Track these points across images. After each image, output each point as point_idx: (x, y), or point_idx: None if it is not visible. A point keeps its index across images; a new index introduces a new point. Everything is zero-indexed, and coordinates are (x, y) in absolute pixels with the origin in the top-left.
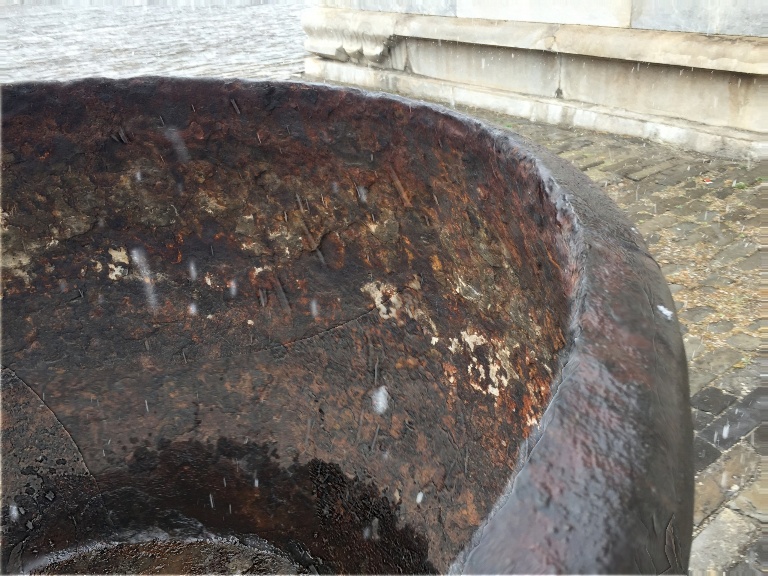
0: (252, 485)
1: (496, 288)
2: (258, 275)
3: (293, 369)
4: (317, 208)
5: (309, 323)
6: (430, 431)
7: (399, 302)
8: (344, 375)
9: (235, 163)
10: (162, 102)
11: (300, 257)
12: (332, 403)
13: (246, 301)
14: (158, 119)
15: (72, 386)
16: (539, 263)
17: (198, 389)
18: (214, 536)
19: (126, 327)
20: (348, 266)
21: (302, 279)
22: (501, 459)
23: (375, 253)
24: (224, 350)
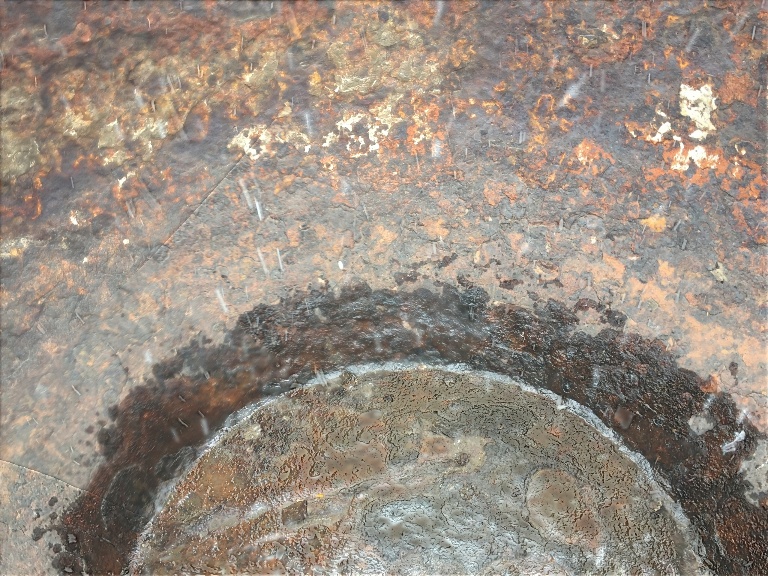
0: (205, 380)
1: (386, 63)
2: (122, 187)
3: (181, 260)
4: (189, 82)
5: (181, 208)
6: (324, 218)
7: (269, 136)
8: (229, 233)
9: (112, 62)
10: (52, 6)
11: (162, 146)
12: (229, 263)
13: (115, 222)
14: (40, 29)
15: (4, 421)
16: (477, 4)
17: (107, 341)
18: (207, 444)
19: (13, 322)
20: (212, 130)
21: (166, 168)
22: (396, 185)
23: (244, 103)
24: (111, 286)
